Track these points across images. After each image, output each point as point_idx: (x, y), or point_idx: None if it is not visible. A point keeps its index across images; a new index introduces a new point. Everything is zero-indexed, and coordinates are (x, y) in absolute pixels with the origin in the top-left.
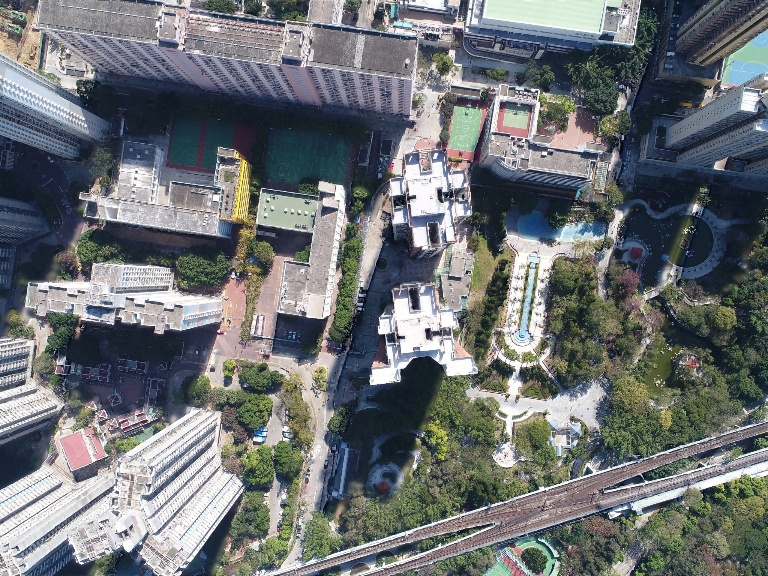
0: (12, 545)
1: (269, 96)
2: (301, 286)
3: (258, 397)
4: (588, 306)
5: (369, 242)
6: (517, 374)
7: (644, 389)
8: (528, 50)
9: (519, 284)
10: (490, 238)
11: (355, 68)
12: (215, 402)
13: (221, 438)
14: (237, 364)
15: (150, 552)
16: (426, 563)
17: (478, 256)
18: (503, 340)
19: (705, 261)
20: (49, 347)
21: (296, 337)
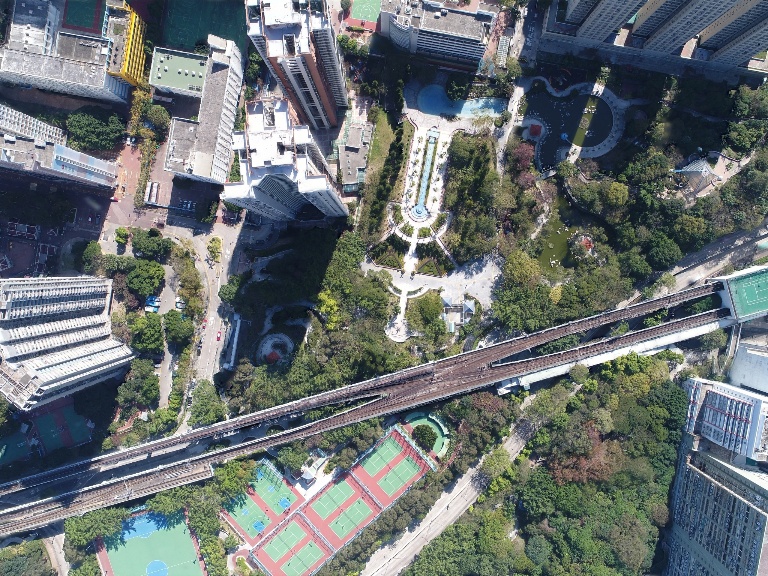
0: None
1: None
2: (190, 144)
3: (149, 263)
4: (482, 178)
5: None
6: (413, 250)
7: (536, 264)
8: None
9: (418, 159)
10: (390, 111)
11: None
12: (105, 267)
13: (113, 308)
14: (130, 231)
15: (3, 379)
16: (313, 433)
17: (378, 129)
18: (397, 211)
19: (604, 141)
20: None
21: (191, 206)
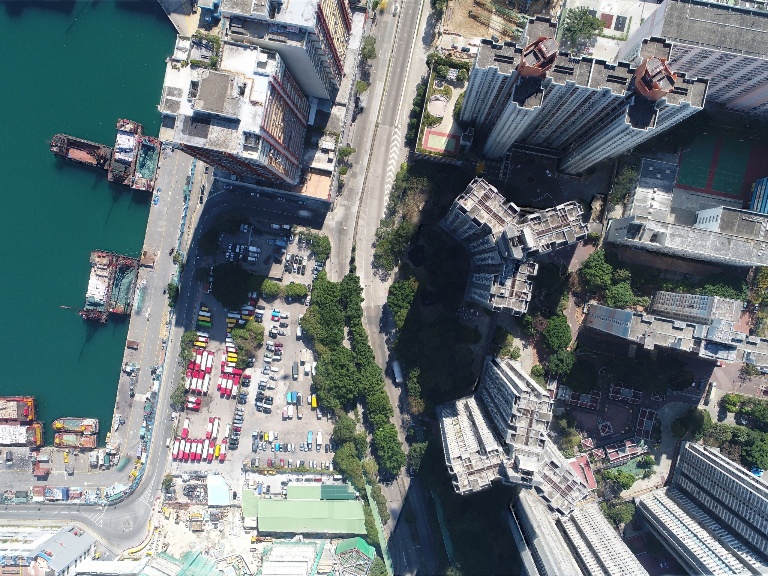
0: None
1: None
2: None
3: None
4: None
5: None
6: None
7: None
8: None
9: None
10: None
11: None
12: (721, 439)
13: None
14: (740, 399)
15: None
16: None
17: None
18: None
19: None
20: None
21: None
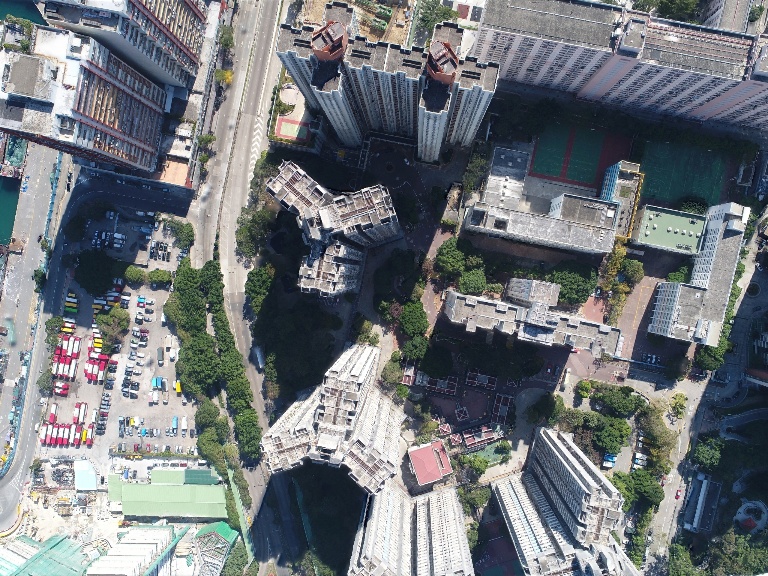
0: (465, 572)
1: (654, 108)
2: (695, 311)
3: (620, 422)
4: None
5: None
6: None
7: None
8: None
9: None
10: None
11: None
12: (573, 424)
13: None
14: (593, 385)
15: None
16: None
17: None
18: None
19: None
20: (399, 356)
21: (655, 361)
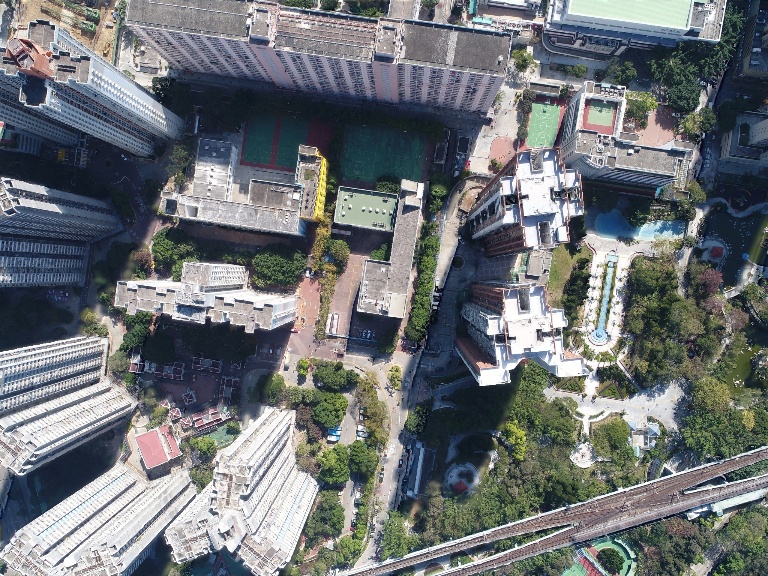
0: (110, 544)
1: (346, 93)
2: (382, 285)
3: (334, 396)
4: (670, 306)
5: (445, 240)
6: (594, 374)
7: (726, 389)
8: (610, 46)
9: (597, 283)
10: None
11: (447, 65)
12: (291, 401)
13: (294, 437)
14: (312, 363)
15: (248, 552)
16: (504, 563)
17: (555, 255)
18: (582, 340)
19: None
20: (124, 345)
21: (371, 336)
